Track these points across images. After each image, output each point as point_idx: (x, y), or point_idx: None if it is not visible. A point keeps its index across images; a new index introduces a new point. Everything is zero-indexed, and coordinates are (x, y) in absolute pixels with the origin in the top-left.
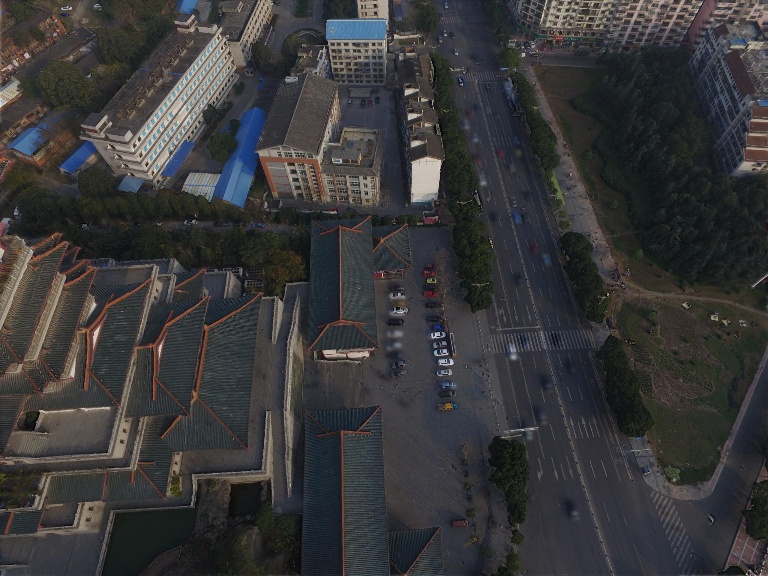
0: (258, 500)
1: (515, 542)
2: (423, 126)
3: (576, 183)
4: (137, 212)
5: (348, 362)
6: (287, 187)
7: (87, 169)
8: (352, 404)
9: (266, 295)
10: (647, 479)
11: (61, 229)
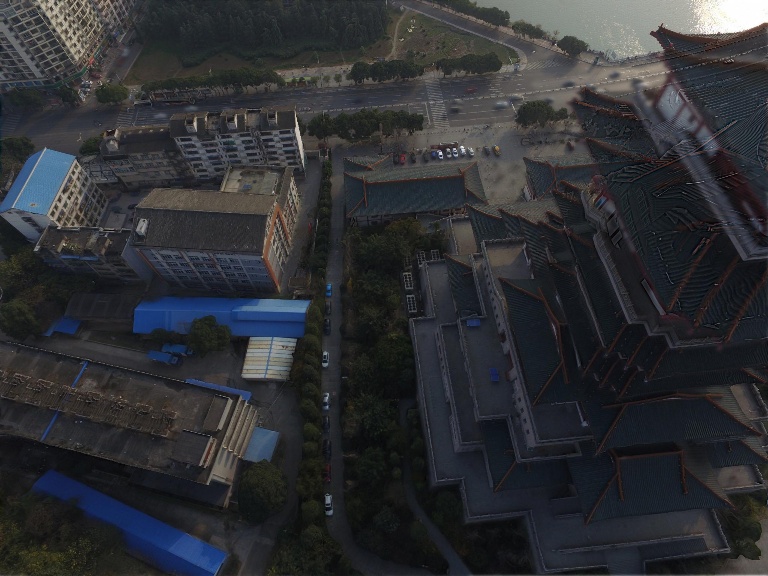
0: None
1: (576, 117)
2: (245, 120)
3: (288, 73)
4: (317, 416)
5: None
6: (277, 267)
7: (253, 485)
8: None
9: (434, 247)
10: (520, 69)
11: (358, 497)
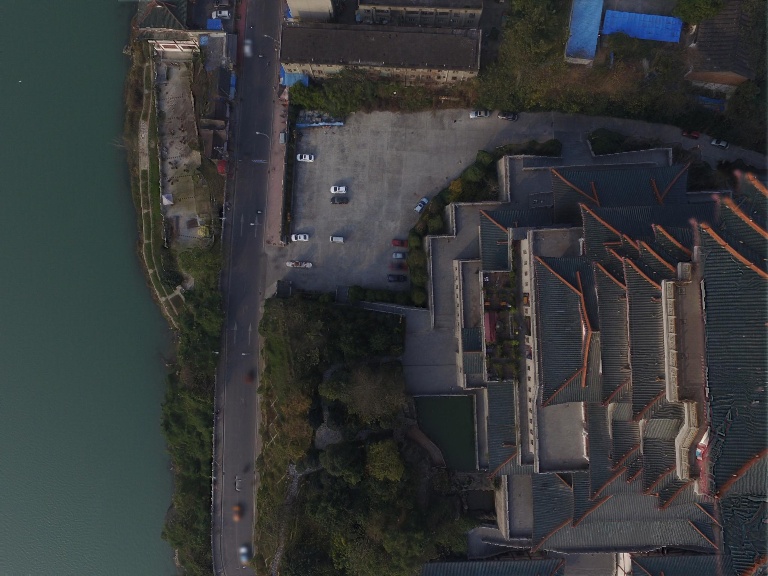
0: (479, 507)
1: None
2: None
3: None
4: None
5: (613, 570)
6: None
7: None
8: (566, 572)
9: None
10: None
11: None
